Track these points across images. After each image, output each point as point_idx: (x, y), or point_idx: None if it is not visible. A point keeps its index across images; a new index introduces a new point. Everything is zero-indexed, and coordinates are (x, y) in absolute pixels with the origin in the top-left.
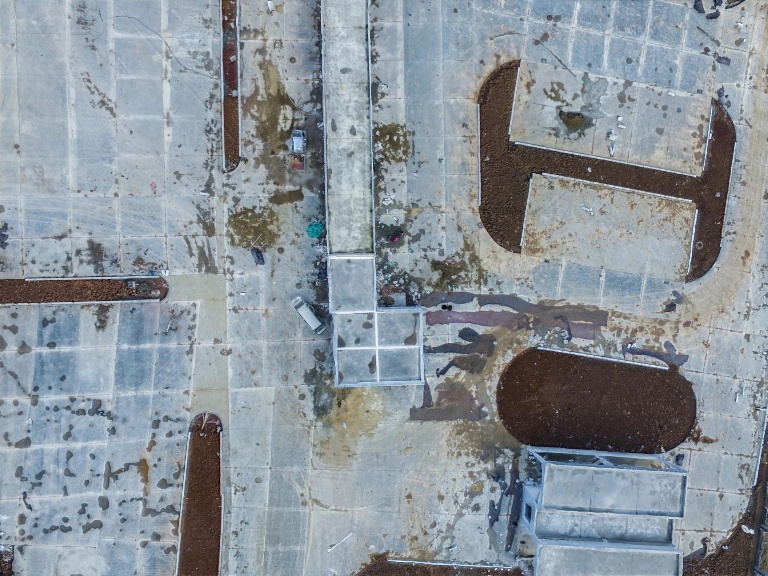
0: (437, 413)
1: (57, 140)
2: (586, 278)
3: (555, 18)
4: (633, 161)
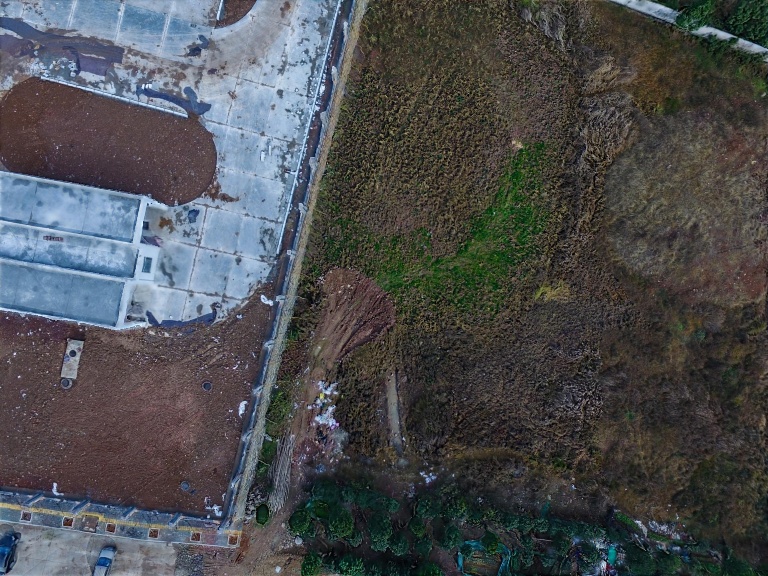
0: None
1: None
2: (103, 11)
3: None
4: None
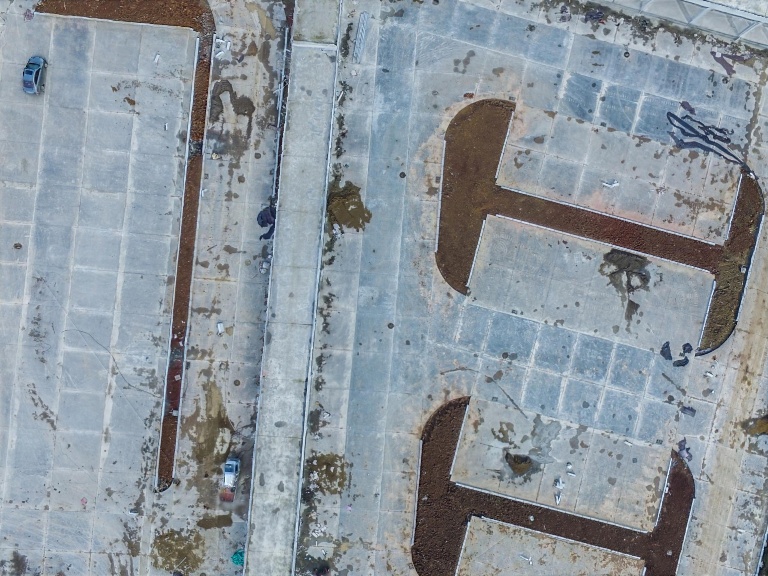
0: None
1: None
2: None
3: (511, 356)
4: (580, 511)
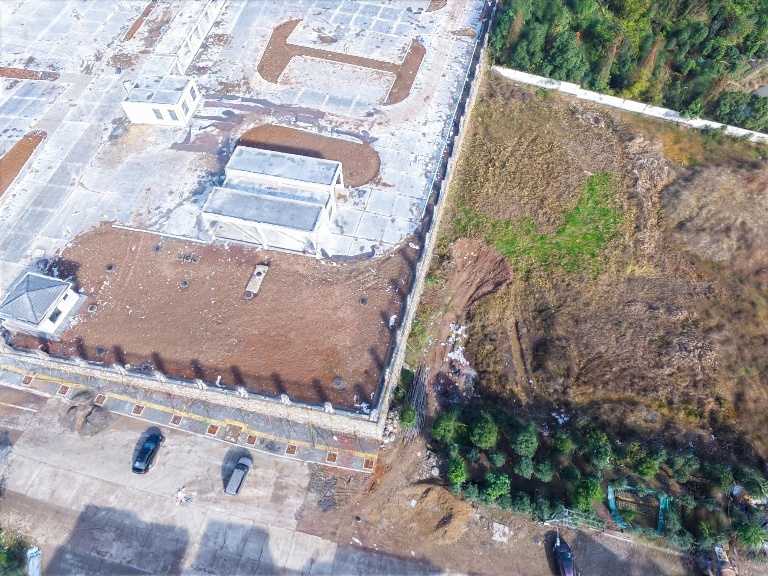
0: (190, 147)
1: (44, 24)
2: (315, 97)
3: (327, 8)
4: (358, 55)
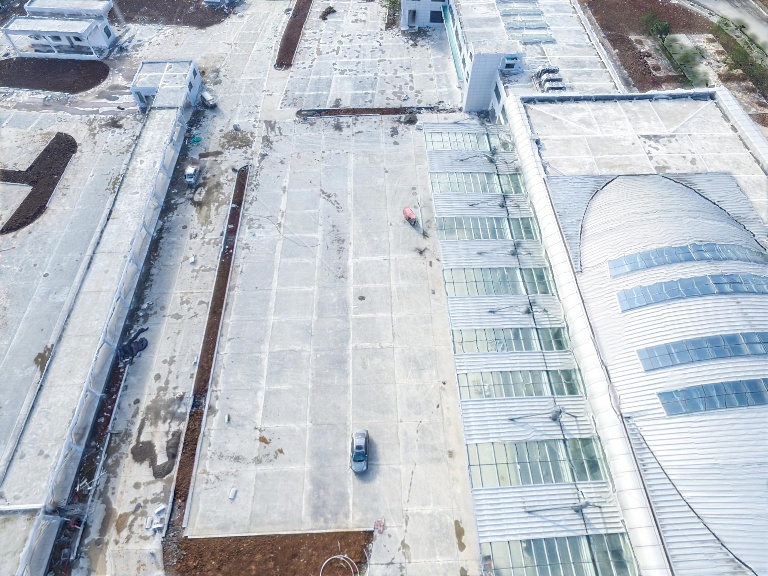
0: None
1: (360, 176)
2: (18, 123)
3: None
4: None
